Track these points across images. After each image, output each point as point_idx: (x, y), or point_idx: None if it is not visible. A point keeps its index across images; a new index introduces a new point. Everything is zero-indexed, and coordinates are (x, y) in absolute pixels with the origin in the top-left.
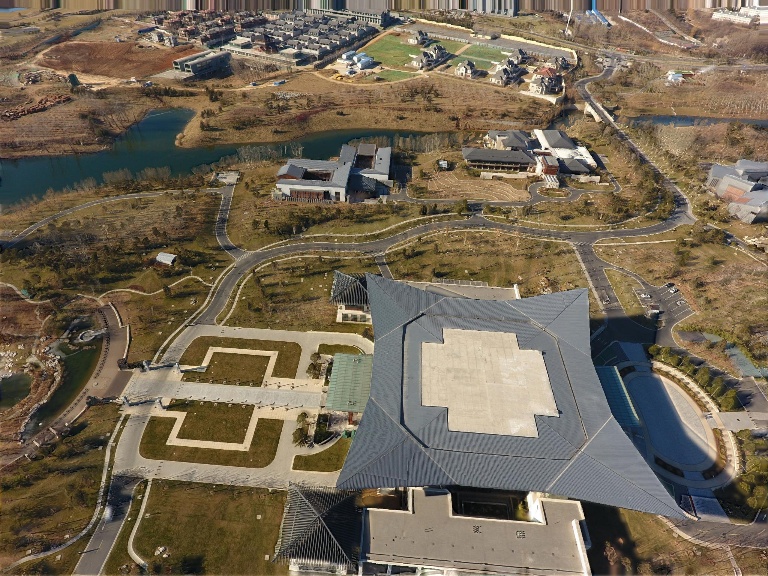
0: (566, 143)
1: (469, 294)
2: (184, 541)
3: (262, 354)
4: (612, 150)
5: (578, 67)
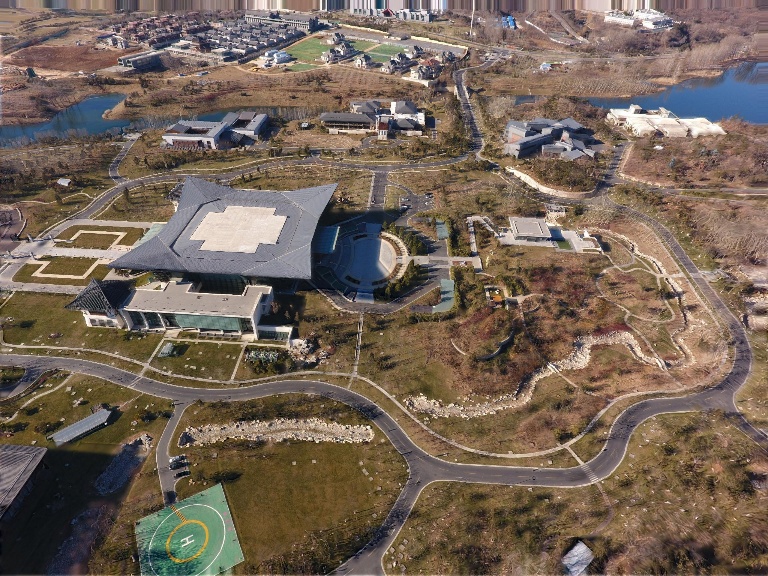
0: (408, 110)
1: None
2: (25, 315)
3: (115, 234)
4: (447, 115)
5: (463, 60)
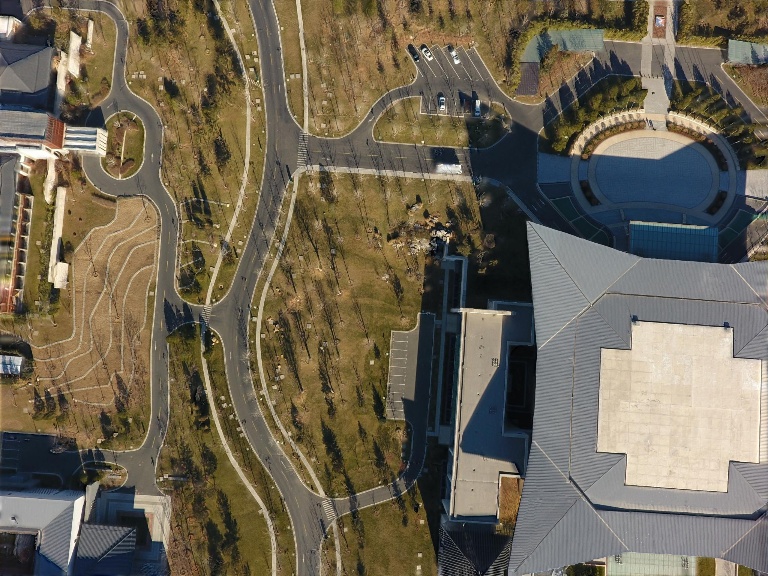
0: None
1: (478, 386)
2: None
3: None
4: None
5: None
